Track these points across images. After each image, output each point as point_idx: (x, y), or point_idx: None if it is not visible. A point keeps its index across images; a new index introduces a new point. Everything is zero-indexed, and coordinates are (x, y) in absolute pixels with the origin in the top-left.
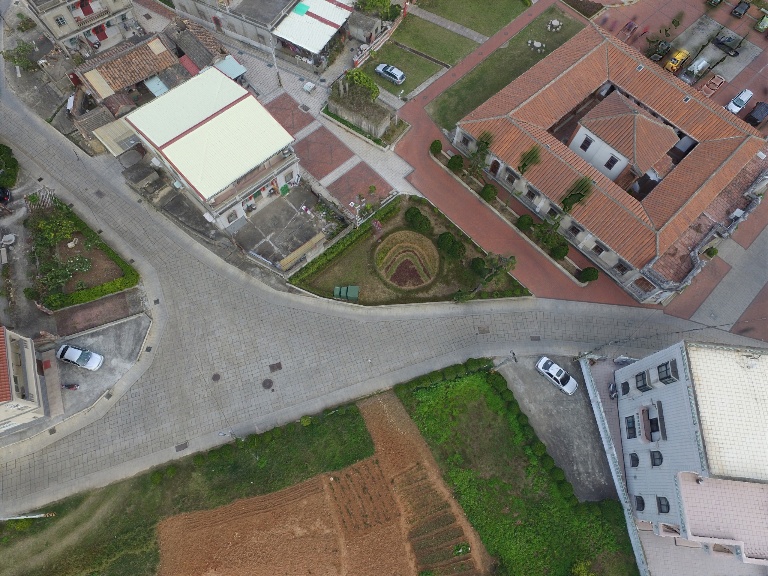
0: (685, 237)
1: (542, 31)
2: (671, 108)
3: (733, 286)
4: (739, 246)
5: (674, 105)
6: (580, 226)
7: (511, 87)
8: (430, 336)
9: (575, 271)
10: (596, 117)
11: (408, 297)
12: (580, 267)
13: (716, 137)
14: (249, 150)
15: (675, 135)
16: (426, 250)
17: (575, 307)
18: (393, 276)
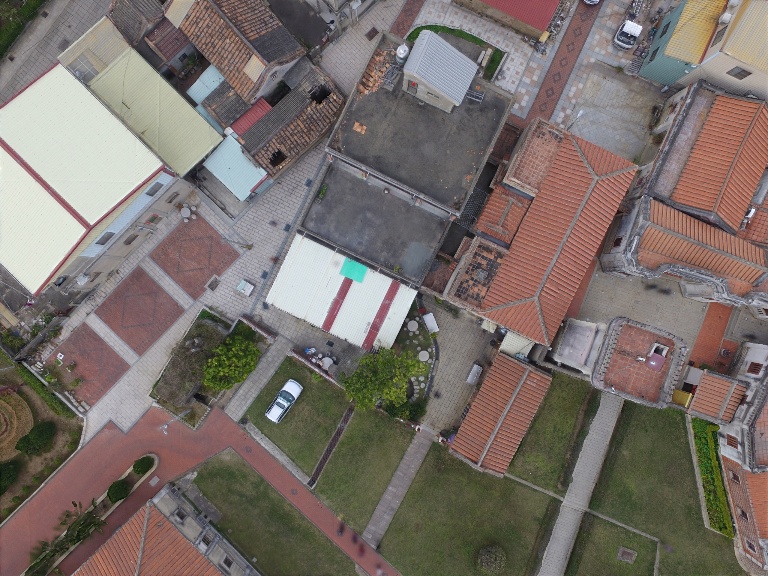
0: None
1: None
2: None
3: None
4: None
5: None
6: None
7: None
8: None
9: None
10: None
11: None
12: None
13: None
14: (6, 237)
15: None
16: (8, 446)
17: None
18: None
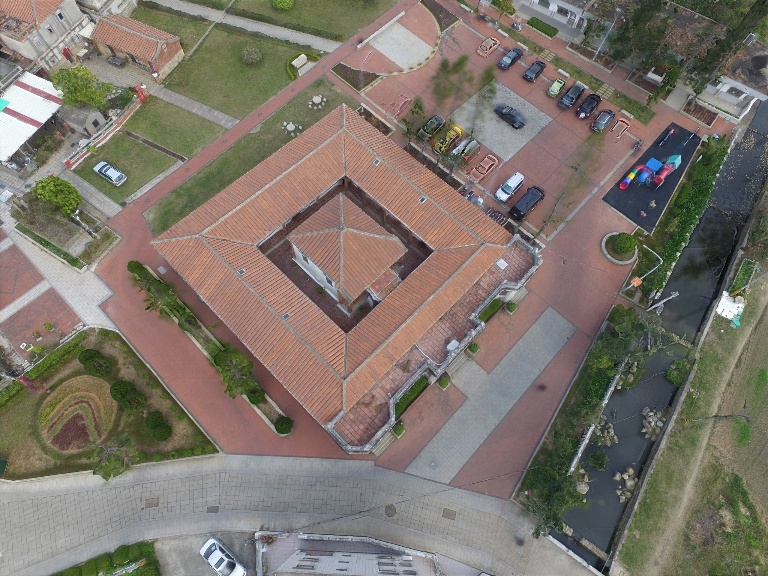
0: (387, 379)
1: (303, 109)
2: (407, 210)
3: (464, 423)
4: (481, 370)
5: (410, 206)
6: (269, 370)
7: (226, 192)
8: (83, 516)
9: (277, 417)
10: (305, 231)
11: (67, 465)
12: (285, 410)
13: (451, 245)
14: None
15: (400, 246)
16: (103, 400)
17: (269, 464)
18: (55, 437)
